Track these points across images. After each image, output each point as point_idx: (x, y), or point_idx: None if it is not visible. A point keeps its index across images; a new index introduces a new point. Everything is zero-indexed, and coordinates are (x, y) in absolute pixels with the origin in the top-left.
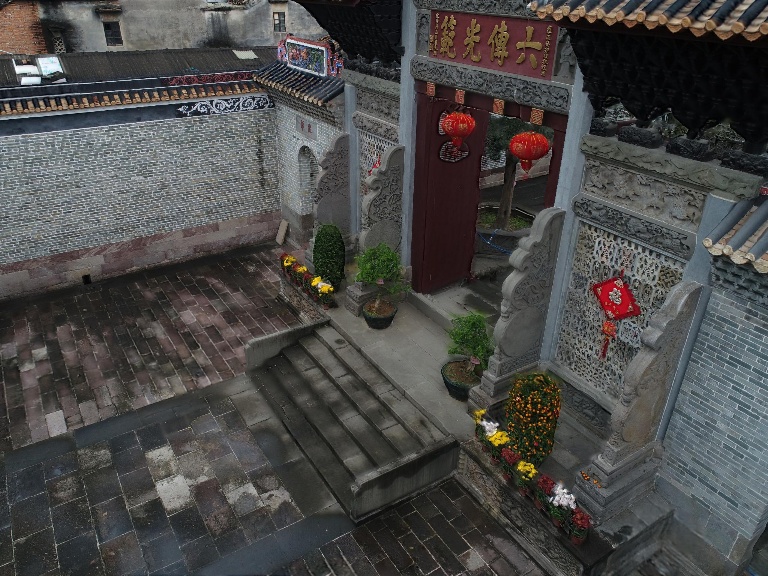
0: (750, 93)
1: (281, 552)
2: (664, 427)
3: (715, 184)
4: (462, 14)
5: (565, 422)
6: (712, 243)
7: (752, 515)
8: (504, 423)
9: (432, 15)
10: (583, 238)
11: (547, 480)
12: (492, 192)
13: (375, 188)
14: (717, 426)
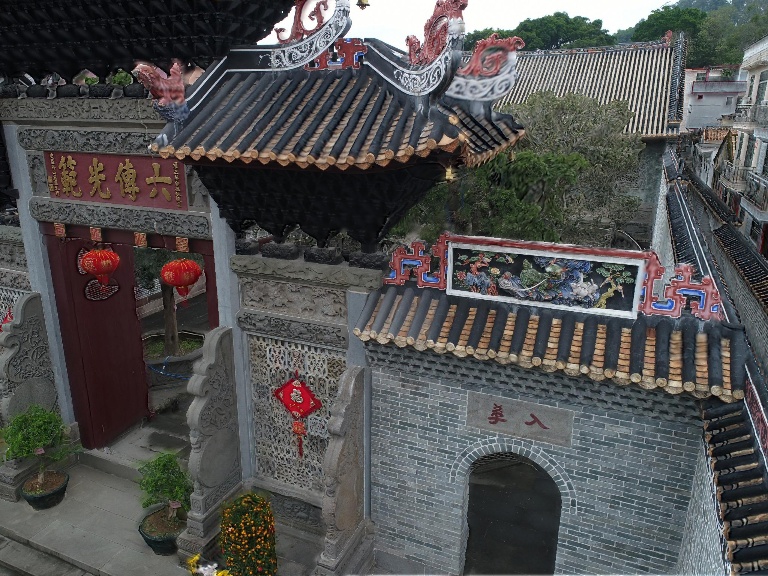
0: (354, 207)
1: None
2: (368, 503)
3: (349, 282)
4: (80, 154)
5: (282, 533)
6: (360, 331)
7: (453, 552)
8: (222, 560)
9: (45, 156)
10: (254, 350)
11: None
12: (154, 319)
13: (11, 346)
14: (407, 485)
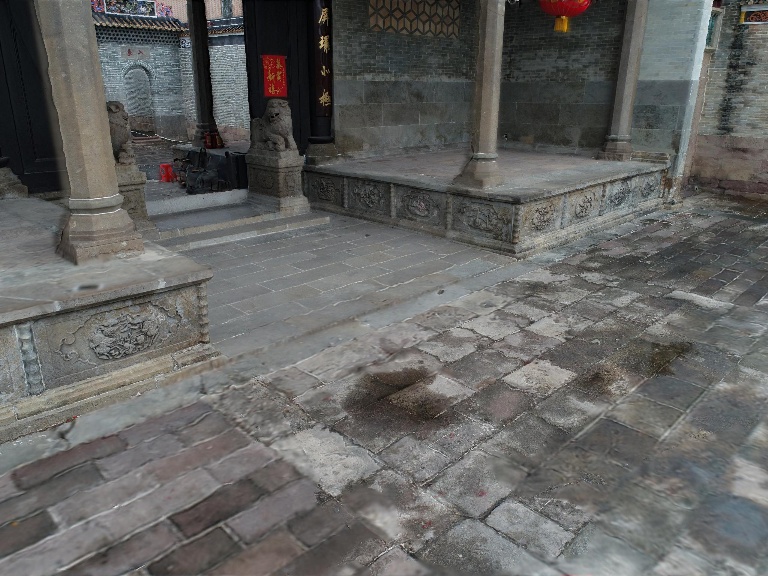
0: None
1: None
2: None
3: None
4: None
5: None
6: None
7: None
8: None
9: None
10: None
11: None
12: None
13: None
14: (106, 86)
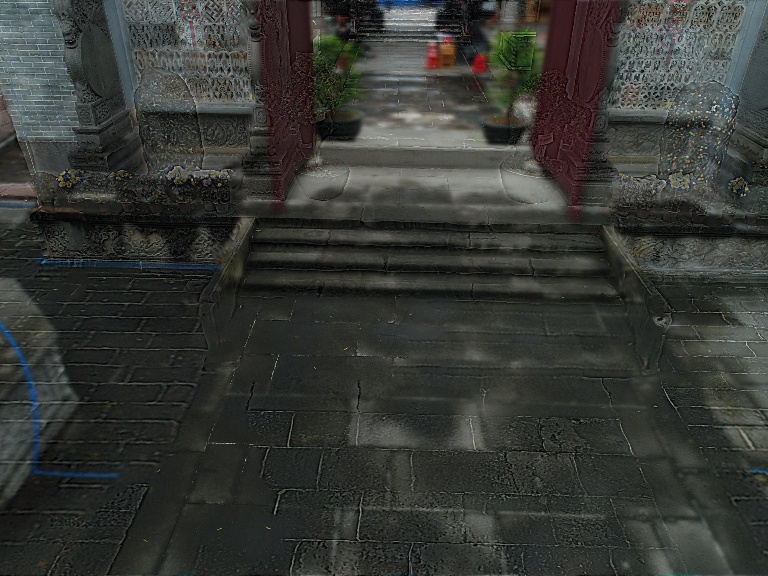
0: None
1: (684, 468)
2: None
3: None
4: None
5: (622, 172)
6: None
7: None
8: None
9: None
10: None
11: (761, 183)
12: None
13: None
14: None
